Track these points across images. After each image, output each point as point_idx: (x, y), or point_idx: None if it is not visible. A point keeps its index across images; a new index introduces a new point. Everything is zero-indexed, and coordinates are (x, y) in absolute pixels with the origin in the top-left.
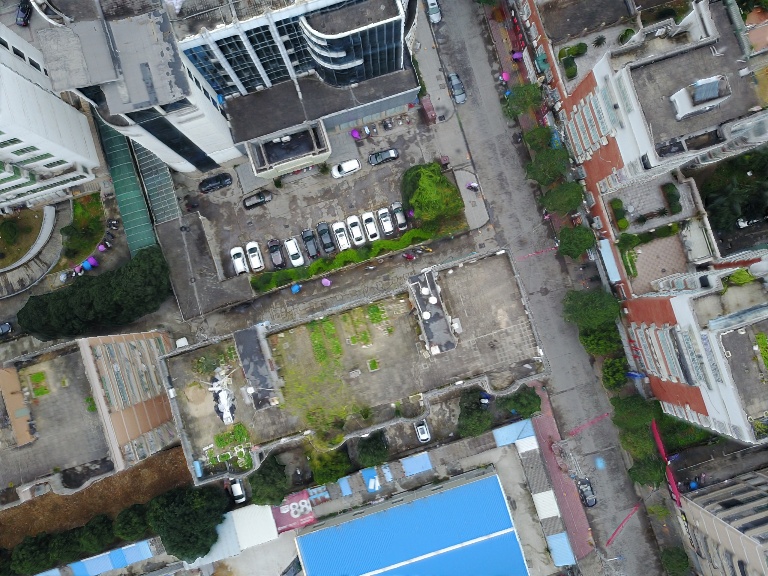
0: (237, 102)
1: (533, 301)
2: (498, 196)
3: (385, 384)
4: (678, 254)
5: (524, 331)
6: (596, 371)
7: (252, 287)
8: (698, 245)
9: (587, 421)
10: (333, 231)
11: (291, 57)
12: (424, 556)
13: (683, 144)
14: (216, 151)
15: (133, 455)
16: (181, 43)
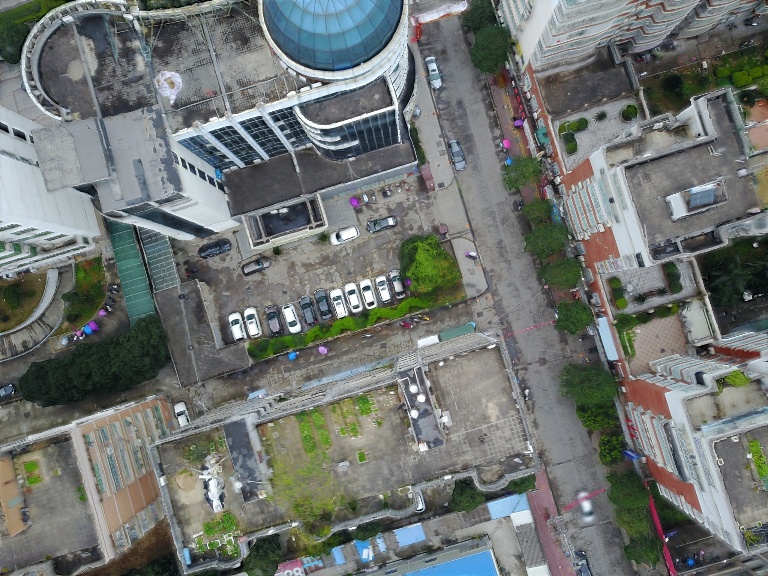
0: (235, 175)
1: (531, 371)
2: (497, 264)
3: (374, 476)
4: (678, 334)
5: (515, 425)
6: (594, 443)
7: (249, 354)
8: (699, 325)
9: (584, 494)
10: (330, 299)
11: (287, 136)
12: None
13: (678, 245)
14: (213, 224)
15: (125, 540)
16: (174, 136)
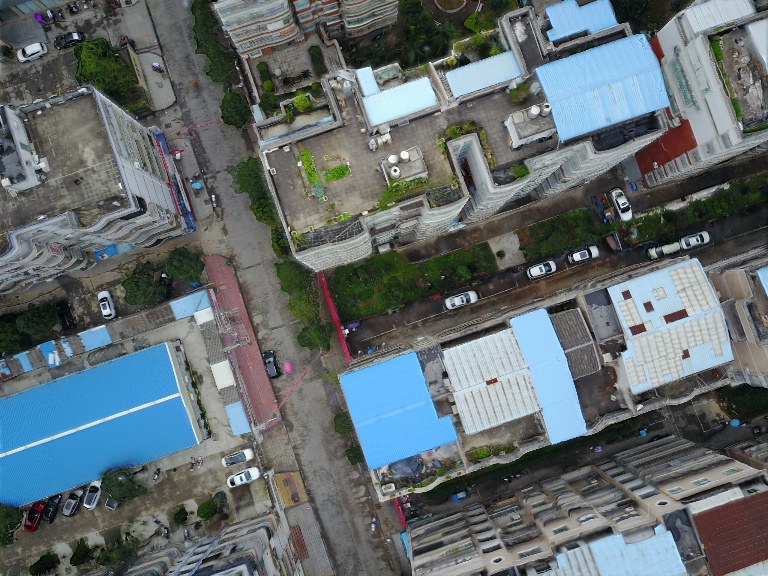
0: None
1: (220, 179)
2: (185, 77)
3: None
4: None
5: (110, 168)
6: None
7: None
8: None
9: (273, 295)
10: None
11: None
12: (91, 424)
13: None
14: None
15: None
16: None
